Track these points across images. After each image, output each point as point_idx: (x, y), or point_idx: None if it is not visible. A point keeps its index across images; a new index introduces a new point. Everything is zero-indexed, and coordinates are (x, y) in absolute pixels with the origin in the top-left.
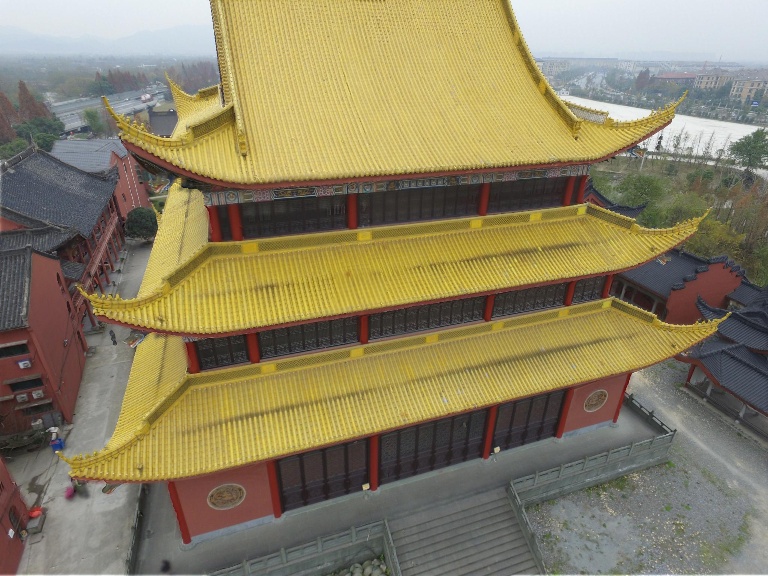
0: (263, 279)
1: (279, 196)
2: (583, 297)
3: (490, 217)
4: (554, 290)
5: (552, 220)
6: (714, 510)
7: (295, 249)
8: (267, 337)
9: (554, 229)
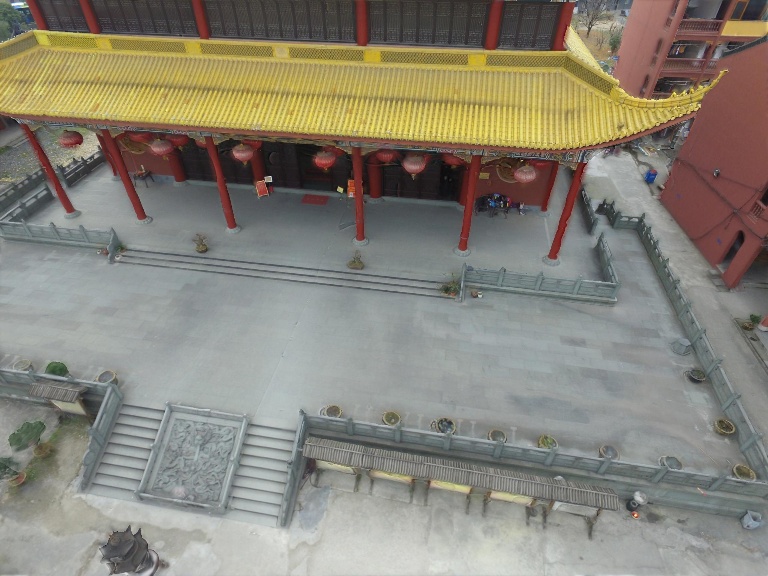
0: None
1: None
2: None
3: None
4: None
5: None
6: None
7: None
8: None
9: None
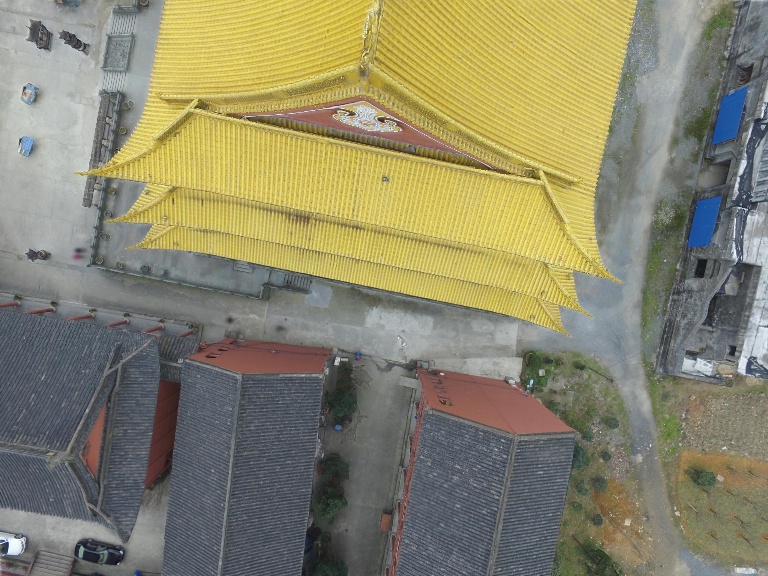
0: None
1: None
2: None
3: None
4: None
5: None
6: None
7: None
8: None
9: None
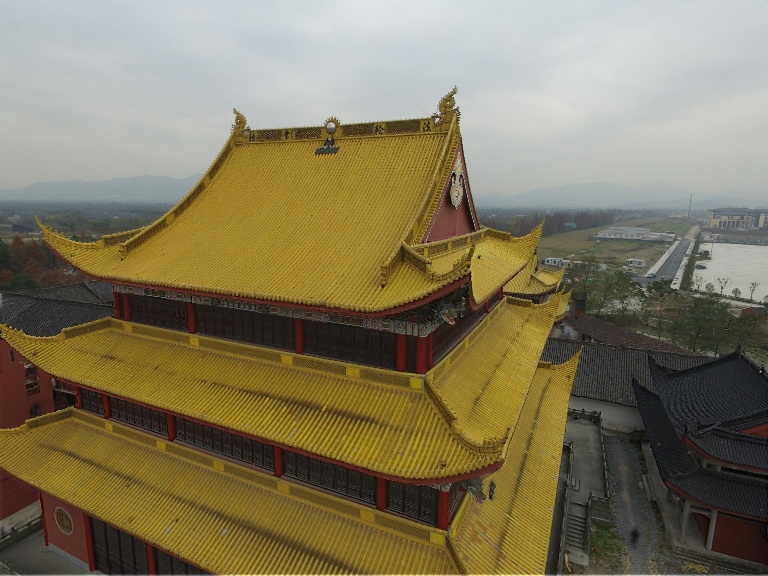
0: (115, 352)
1: (146, 293)
2: (406, 508)
3: (299, 356)
4: (359, 476)
5: (376, 383)
6: None
7: (152, 337)
8: (114, 400)
9: (368, 394)
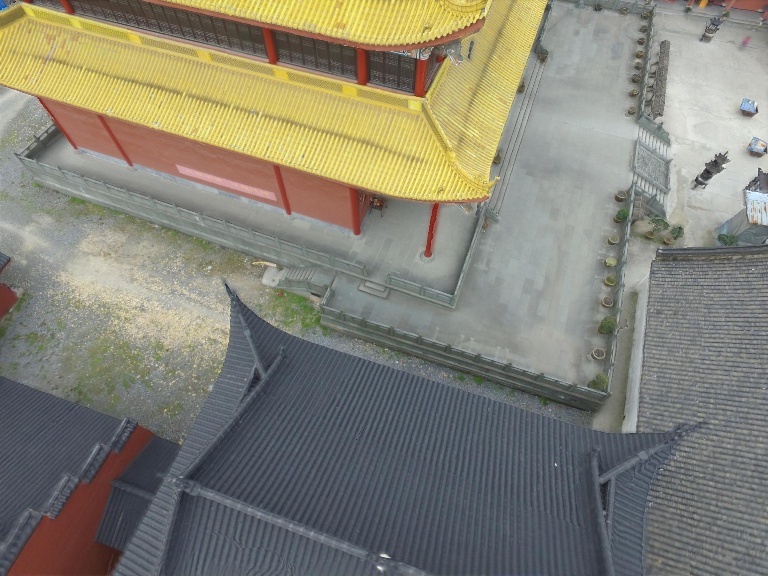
0: None
1: None
2: None
3: None
4: None
5: None
6: (3, 169)
7: None
8: None
9: None
